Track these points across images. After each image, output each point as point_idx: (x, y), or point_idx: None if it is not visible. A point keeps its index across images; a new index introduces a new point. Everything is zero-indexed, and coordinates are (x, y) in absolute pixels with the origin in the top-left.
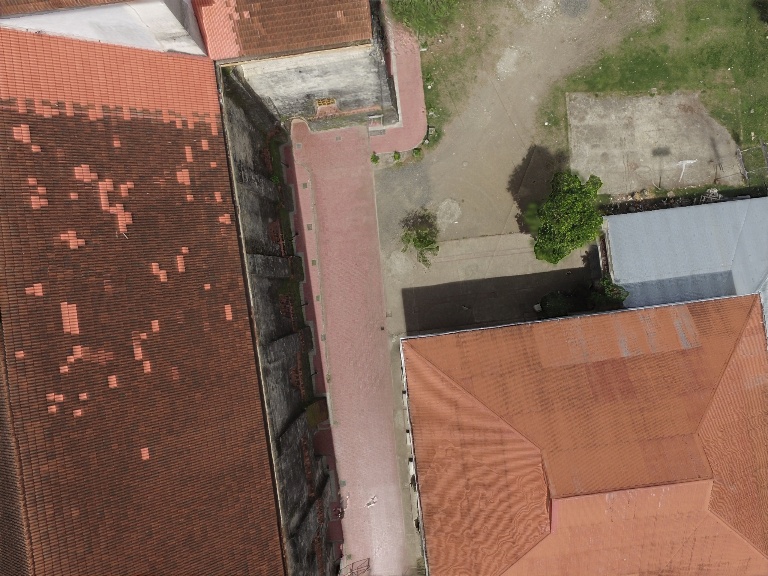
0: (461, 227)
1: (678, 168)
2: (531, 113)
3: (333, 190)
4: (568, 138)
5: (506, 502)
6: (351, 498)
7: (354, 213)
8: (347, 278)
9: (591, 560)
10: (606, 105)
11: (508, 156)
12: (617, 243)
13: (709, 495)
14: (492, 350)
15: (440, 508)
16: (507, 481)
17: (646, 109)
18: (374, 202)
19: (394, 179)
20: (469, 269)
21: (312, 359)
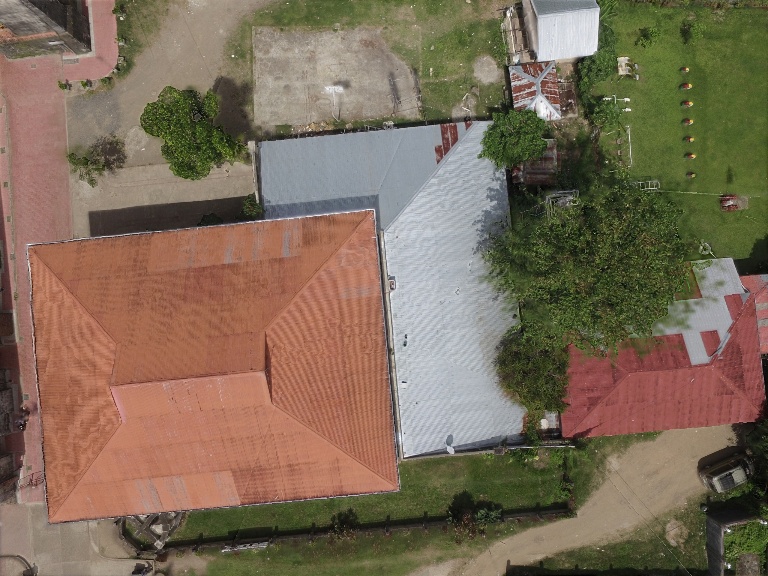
0: (148, 154)
1: (358, 101)
2: (219, 46)
3: (27, 115)
4: (252, 70)
5: (95, 396)
6: (33, 411)
7: (46, 138)
8: (37, 200)
9: (177, 454)
10: (290, 39)
11: (195, 86)
12: (273, 167)
13: (266, 388)
14: (107, 256)
15: (53, 406)
16: (95, 375)
17: (328, 44)
18: (65, 128)
19: (85, 106)
20: (153, 194)
21: (0, 277)
